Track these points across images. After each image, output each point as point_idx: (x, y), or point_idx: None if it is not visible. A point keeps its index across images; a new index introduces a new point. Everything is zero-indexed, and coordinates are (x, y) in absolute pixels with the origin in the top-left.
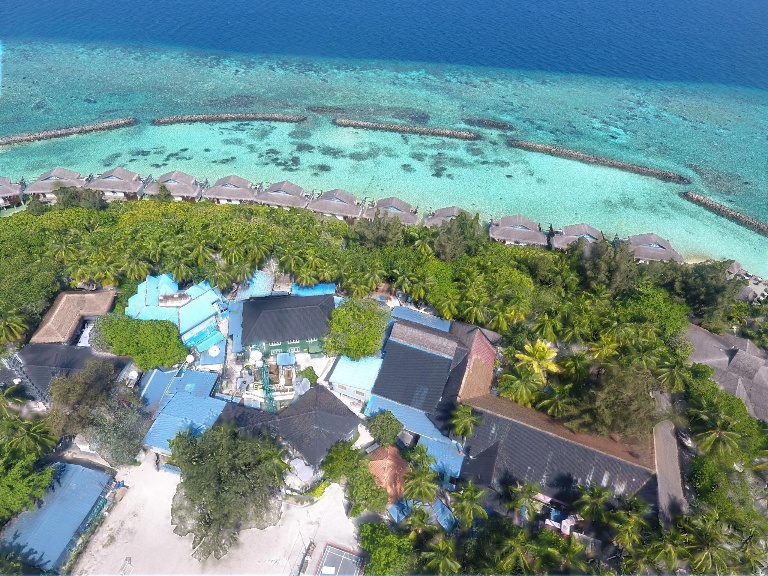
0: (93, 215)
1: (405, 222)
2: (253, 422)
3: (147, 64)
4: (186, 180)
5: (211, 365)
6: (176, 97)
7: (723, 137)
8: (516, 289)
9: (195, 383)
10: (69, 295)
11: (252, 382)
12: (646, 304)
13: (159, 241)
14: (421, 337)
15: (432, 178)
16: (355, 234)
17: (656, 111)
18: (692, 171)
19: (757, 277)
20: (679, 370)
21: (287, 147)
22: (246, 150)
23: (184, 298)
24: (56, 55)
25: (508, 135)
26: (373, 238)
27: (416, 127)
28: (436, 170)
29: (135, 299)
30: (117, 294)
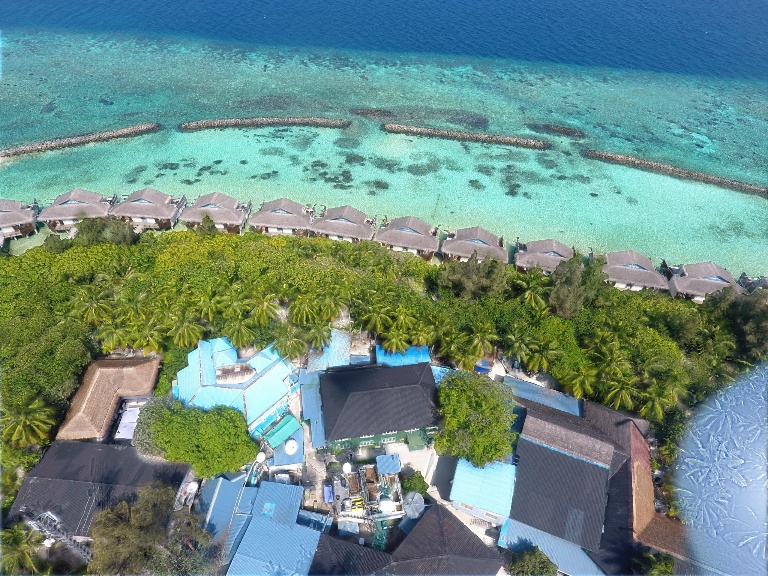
0: (123, 253)
1: (493, 258)
2: (364, 572)
3: (166, 58)
4: (228, 204)
5: (287, 465)
6: (202, 97)
7: None
8: (664, 361)
9: (275, 502)
10: (103, 369)
11: (348, 497)
12: None
13: (211, 295)
14: (564, 436)
15: (506, 197)
16: (447, 281)
17: (738, 114)
18: None
19: None
20: None
21: (334, 158)
22: (288, 162)
23: (247, 372)
24: (65, 48)
25: (581, 143)
26: (472, 288)
27: (477, 134)
28: (509, 187)
29: (186, 374)
30: (162, 364)
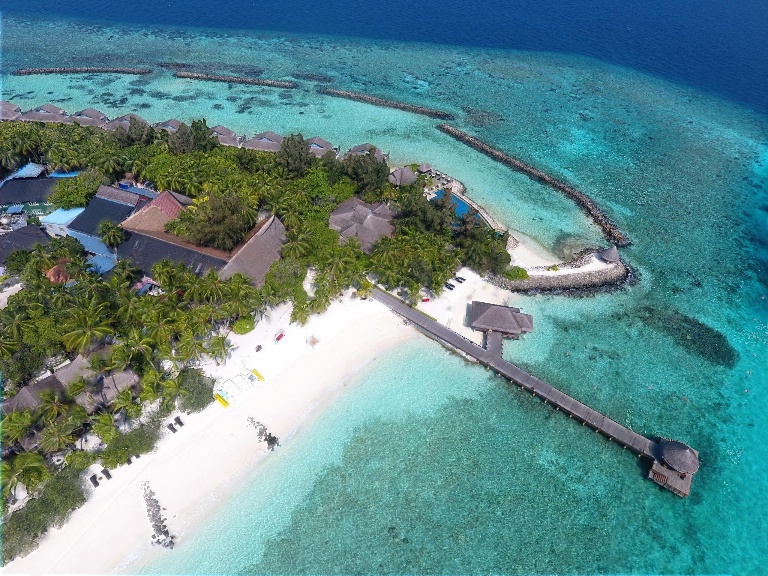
0: None
1: None
2: None
3: (32, 30)
4: (8, 107)
5: None
6: (45, 55)
7: (512, 89)
8: (214, 169)
9: None
10: None
11: None
12: (307, 178)
13: None
14: (116, 193)
15: (234, 114)
16: (113, 137)
17: (470, 70)
18: (463, 111)
19: (445, 176)
20: (306, 216)
21: (122, 91)
22: (85, 93)
23: None
24: None
25: (323, 85)
26: (123, 138)
27: (244, 78)
28: (241, 108)
29: None
30: None
